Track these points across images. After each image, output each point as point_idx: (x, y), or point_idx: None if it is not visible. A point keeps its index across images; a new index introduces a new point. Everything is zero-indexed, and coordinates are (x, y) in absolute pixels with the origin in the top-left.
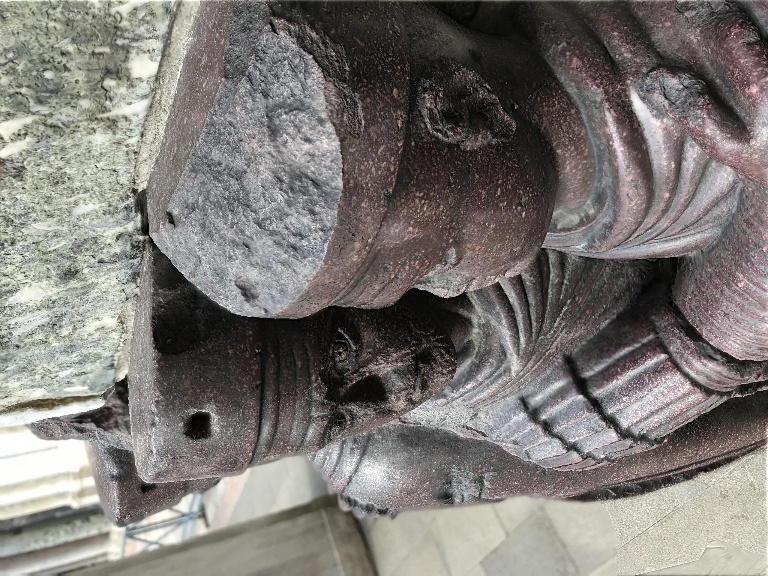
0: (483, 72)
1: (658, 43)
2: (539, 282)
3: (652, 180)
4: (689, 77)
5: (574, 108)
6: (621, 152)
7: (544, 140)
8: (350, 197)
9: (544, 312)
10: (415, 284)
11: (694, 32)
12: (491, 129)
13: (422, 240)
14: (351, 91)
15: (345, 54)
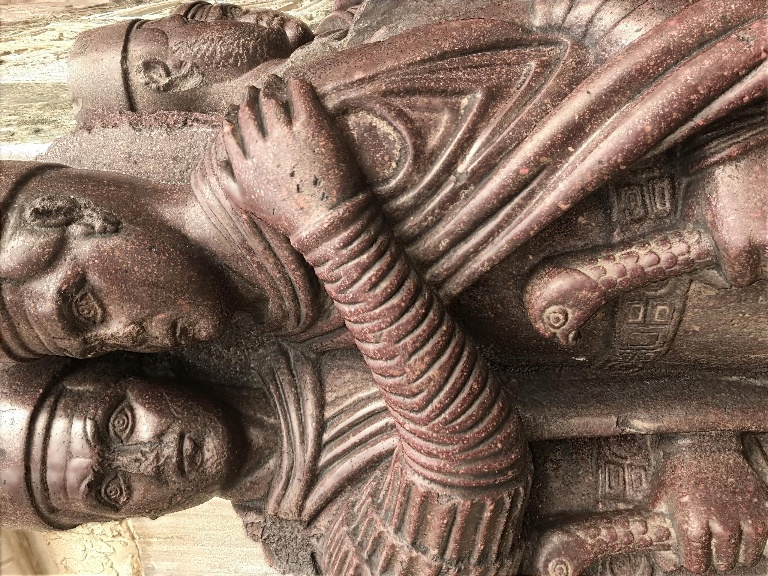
0: None
1: None
2: None
3: None
4: None
5: None
6: None
7: None
8: None
9: None
10: None
11: None
12: None
13: None
14: None
15: None
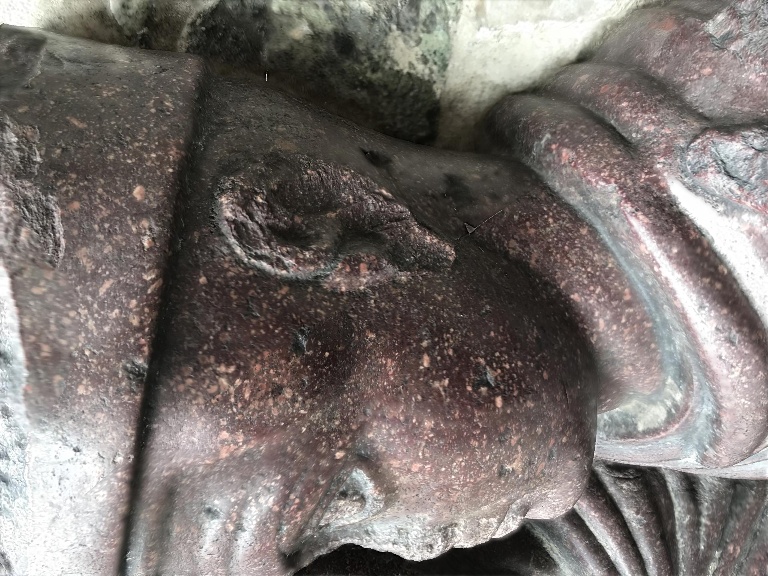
0: (388, 178)
1: (698, 102)
2: (654, 522)
3: (761, 327)
4: (762, 133)
5: (585, 226)
6: (678, 281)
7: (540, 280)
8: (49, 377)
9: (676, 574)
10: (339, 538)
11: (753, 68)
12: (397, 257)
13: (269, 456)
14: (40, 193)
15: (39, 139)
